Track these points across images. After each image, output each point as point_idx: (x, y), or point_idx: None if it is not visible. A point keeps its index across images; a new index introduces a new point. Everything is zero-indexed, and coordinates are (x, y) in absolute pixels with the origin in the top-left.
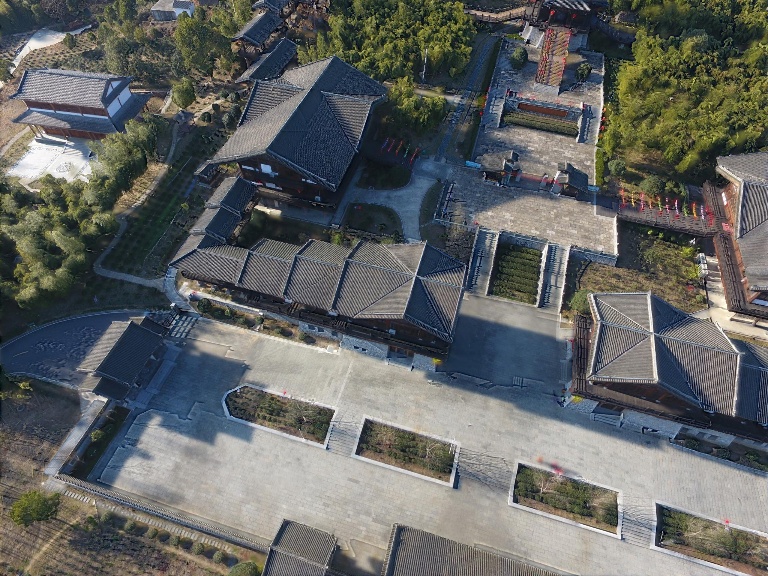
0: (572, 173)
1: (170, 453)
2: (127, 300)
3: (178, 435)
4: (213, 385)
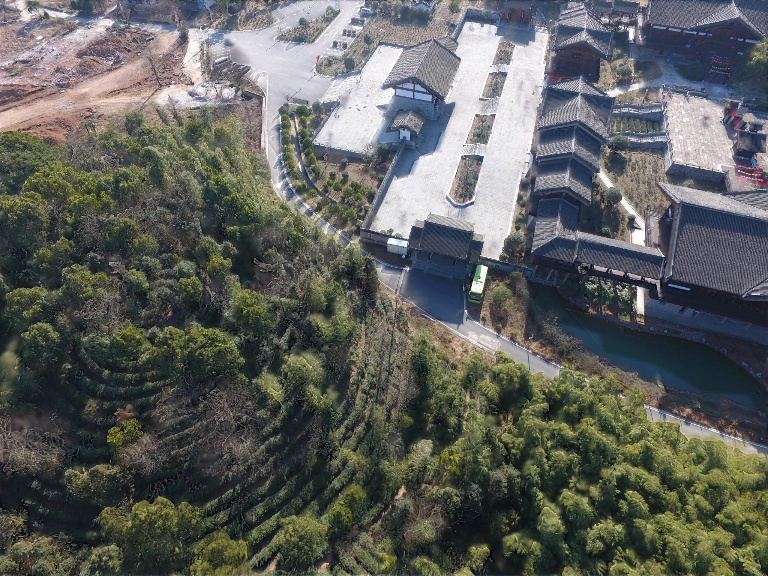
0: (756, 137)
1: (480, 33)
2: (550, 15)
3: (488, 34)
4: (513, 39)
